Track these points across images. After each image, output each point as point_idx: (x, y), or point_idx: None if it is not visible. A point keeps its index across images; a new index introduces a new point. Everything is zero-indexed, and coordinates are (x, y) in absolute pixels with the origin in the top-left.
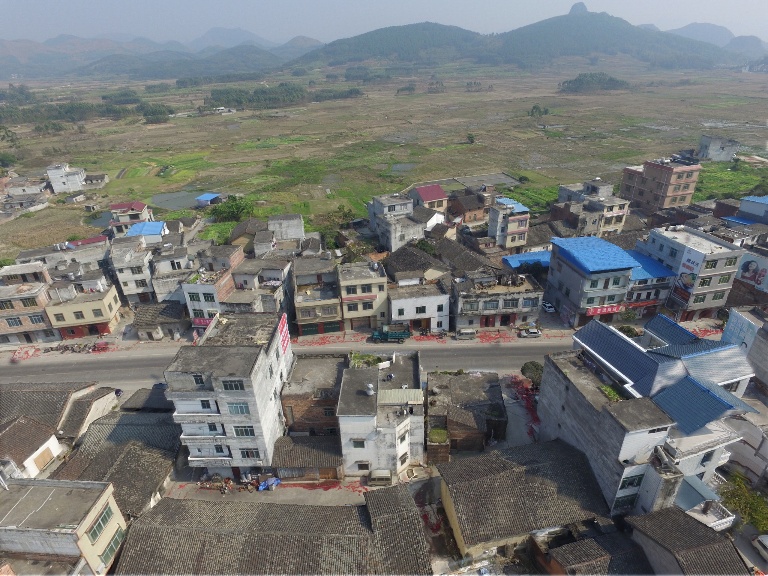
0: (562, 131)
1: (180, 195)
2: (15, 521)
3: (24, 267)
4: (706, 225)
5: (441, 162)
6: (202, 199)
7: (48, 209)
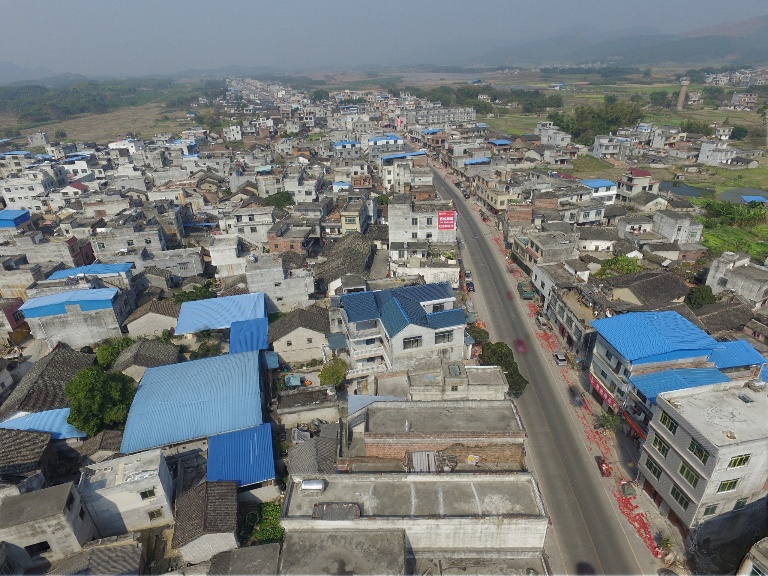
0: None
1: (764, 195)
2: (350, 207)
3: (503, 168)
4: None
5: None
6: (744, 198)
7: (664, 169)
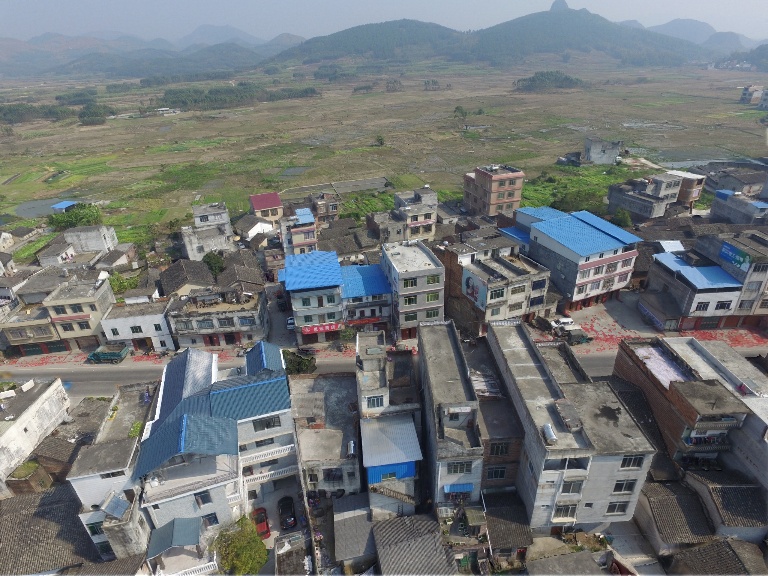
0: (481, 132)
1: (49, 202)
2: None
3: None
4: (476, 237)
5: (335, 166)
6: (57, 207)
7: None
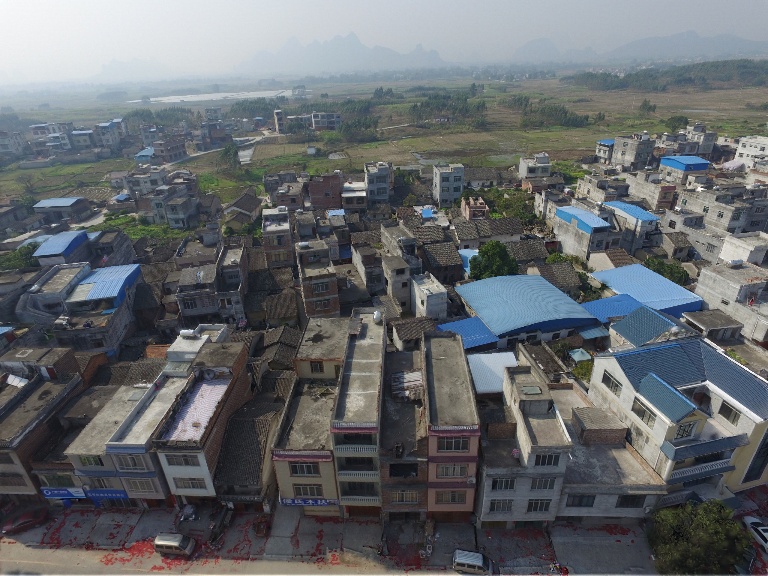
0: None
1: None
2: None
3: None
4: None
5: None
6: None
7: None
